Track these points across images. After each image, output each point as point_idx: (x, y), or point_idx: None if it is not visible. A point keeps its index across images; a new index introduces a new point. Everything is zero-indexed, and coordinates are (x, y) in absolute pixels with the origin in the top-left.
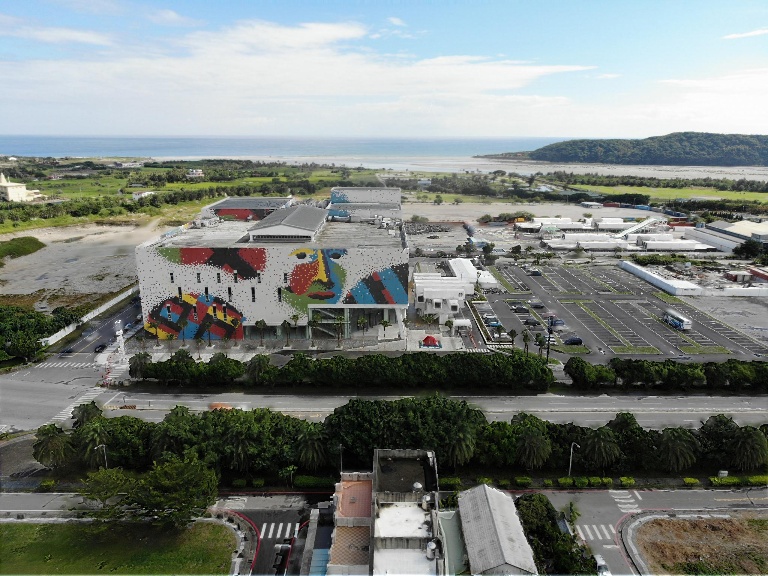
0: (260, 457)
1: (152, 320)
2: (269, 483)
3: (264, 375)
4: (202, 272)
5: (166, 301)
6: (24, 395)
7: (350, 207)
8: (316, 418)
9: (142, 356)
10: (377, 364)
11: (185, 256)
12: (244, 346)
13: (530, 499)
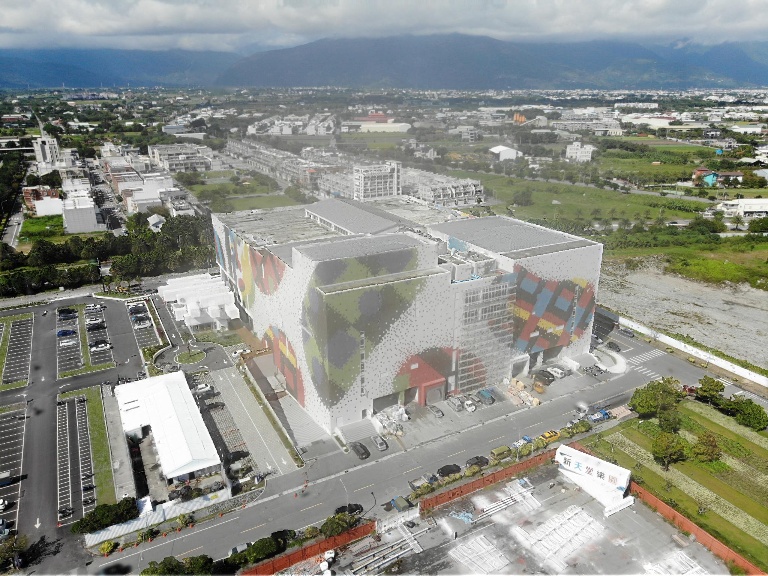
0: None
1: None
2: None
3: None
4: None
5: None
6: None
7: None
8: None
9: None
10: None
11: None
12: None
13: (145, 230)
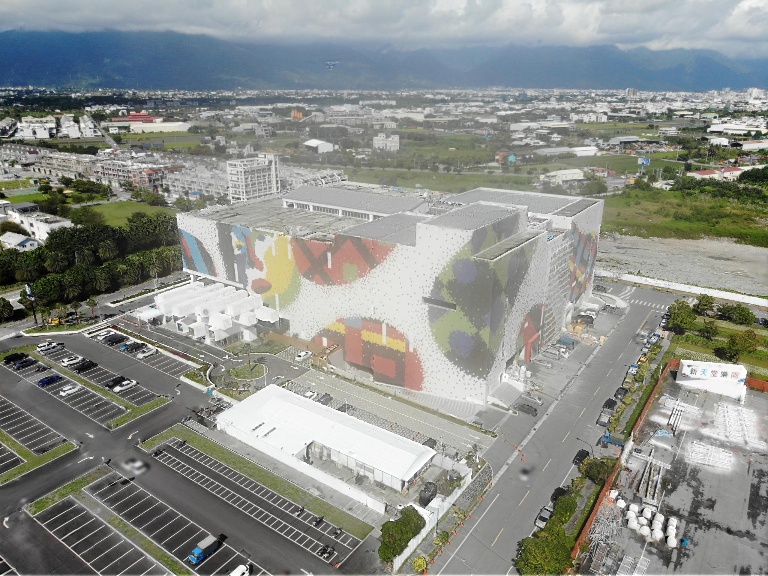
0: None
1: None
2: None
3: None
4: None
5: None
6: None
7: None
8: None
9: None
10: None
11: None
12: None
13: None
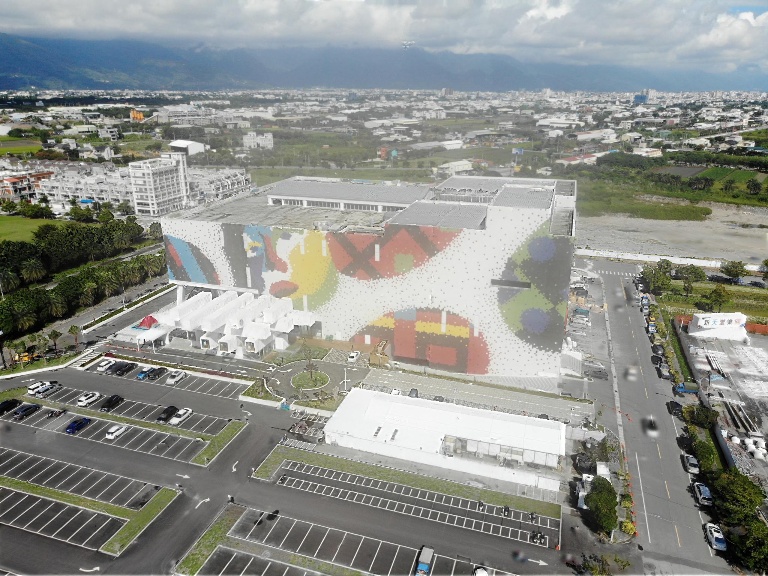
0: None
1: None
2: None
3: None
4: None
5: None
6: None
7: None
8: None
9: None
10: None
11: None
12: None
13: None
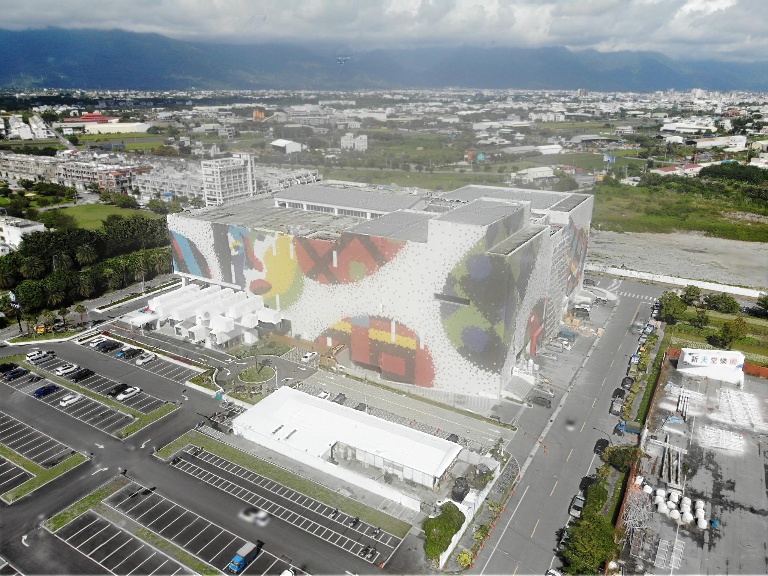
0: None
1: None
2: None
3: None
4: None
5: None
6: None
7: None
8: None
9: None
10: None
11: None
12: None
13: None
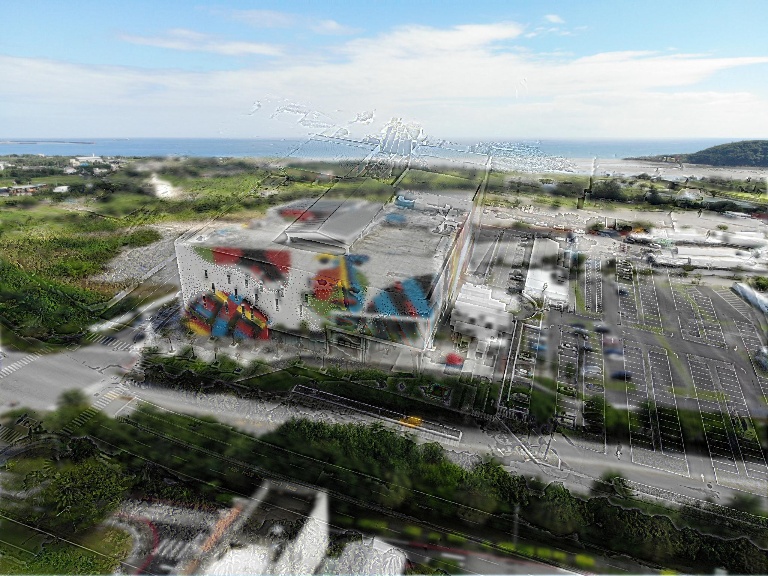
0: (180, 563)
1: (191, 304)
2: (192, 575)
3: (249, 419)
4: (232, 275)
5: (202, 292)
6: (64, 380)
7: (424, 181)
8: (275, 487)
9: (155, 369)
10: (347, 443)
11: (217, 258)
12: (263, 351)
13: None
